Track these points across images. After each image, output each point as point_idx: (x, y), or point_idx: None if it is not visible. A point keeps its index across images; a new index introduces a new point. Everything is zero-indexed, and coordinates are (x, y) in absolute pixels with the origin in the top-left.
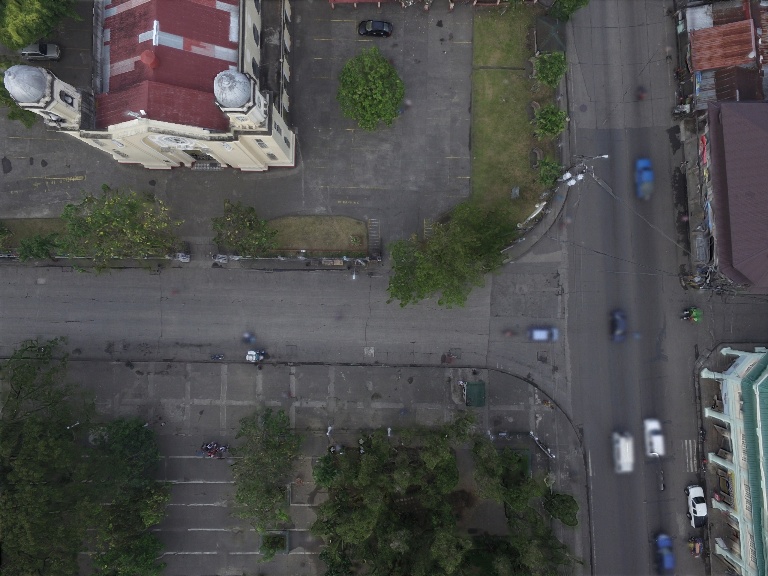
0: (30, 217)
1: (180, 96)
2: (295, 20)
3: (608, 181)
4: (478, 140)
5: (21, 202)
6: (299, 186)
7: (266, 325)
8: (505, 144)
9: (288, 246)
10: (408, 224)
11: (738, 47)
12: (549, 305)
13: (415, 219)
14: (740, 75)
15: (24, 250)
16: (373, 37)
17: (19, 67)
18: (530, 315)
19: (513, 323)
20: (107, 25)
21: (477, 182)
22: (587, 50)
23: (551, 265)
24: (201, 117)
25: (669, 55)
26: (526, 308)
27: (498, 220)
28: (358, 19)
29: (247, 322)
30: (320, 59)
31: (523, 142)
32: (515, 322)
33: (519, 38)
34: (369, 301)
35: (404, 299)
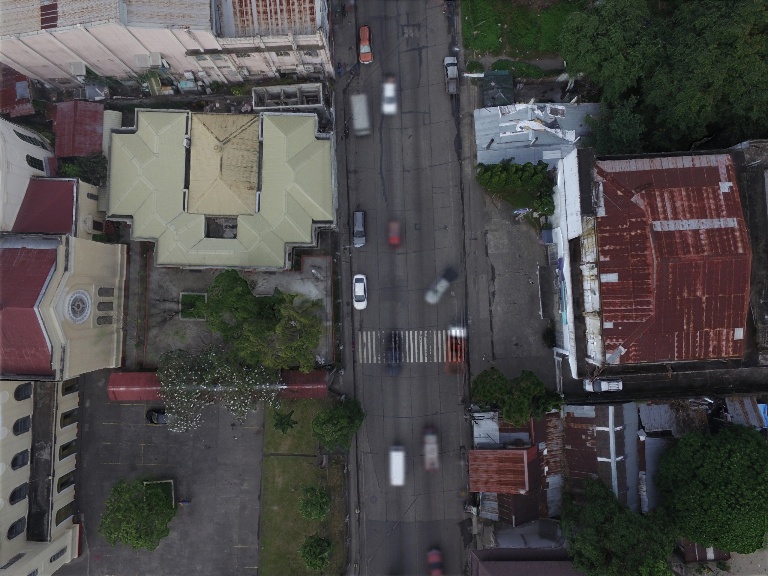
0: None
1: None
2: (84, 404)
3: (397, 575)
4: (267, 529)
5: None
6: (84, 574)
7: None
8: (294, 533)
9: None
10: None
11: (512, 477)
12: None
13: None
14: (518, 498)
15: None
16: None
17: None
18: None
19: None
20: None
21: (265, 573)
22: (379, 439)
23: None
24: None
25: (463, 445)
26: None
27: None
28: (148, 403)
29: None
30: (109, 444)
31: (313, 532)
32: None
33: None
34: None
35: None
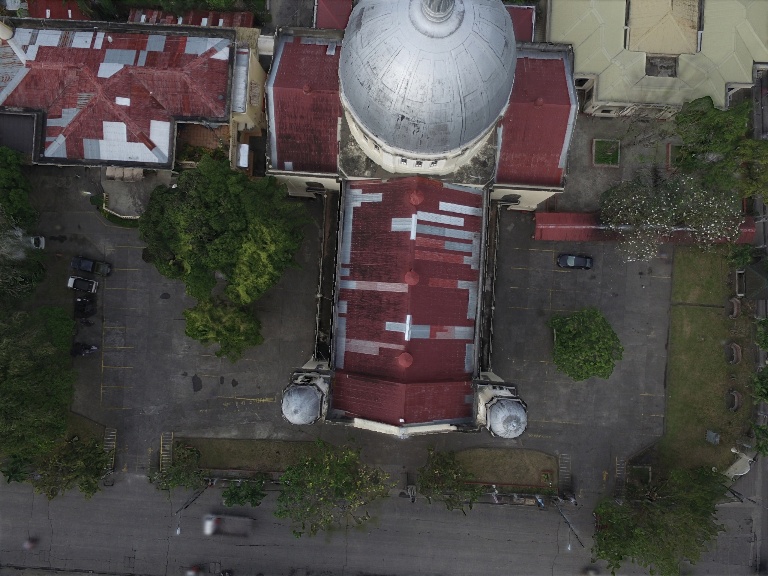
0: (218, 437)
1: (430, 392)
2: None
3: None
4: (674, 378)
5: (210, 421)
6: None
7: (452, 558)
8: (701, 383)
9: (477, 478)
10: (599, 461)
11: None
12: (741, 552)
13: (607, 456)
14: None
15: (233, 499)
16: (572, 269)
17: (301, 398)
18: (721, 561)
19: (703, 568)
20: (343, 297)
21: (671, 421)
22: None
23: (745, 511)
24: (446, 409)
25: None
26: (717, 554)
27: (711, 487)
28: (557, 249)
29: (433, 554)
30: (516, 288)
31: (720, 382)
32: (705, 567)
33: (720, 276)
34: (557, 539)
35: (615, 567)
